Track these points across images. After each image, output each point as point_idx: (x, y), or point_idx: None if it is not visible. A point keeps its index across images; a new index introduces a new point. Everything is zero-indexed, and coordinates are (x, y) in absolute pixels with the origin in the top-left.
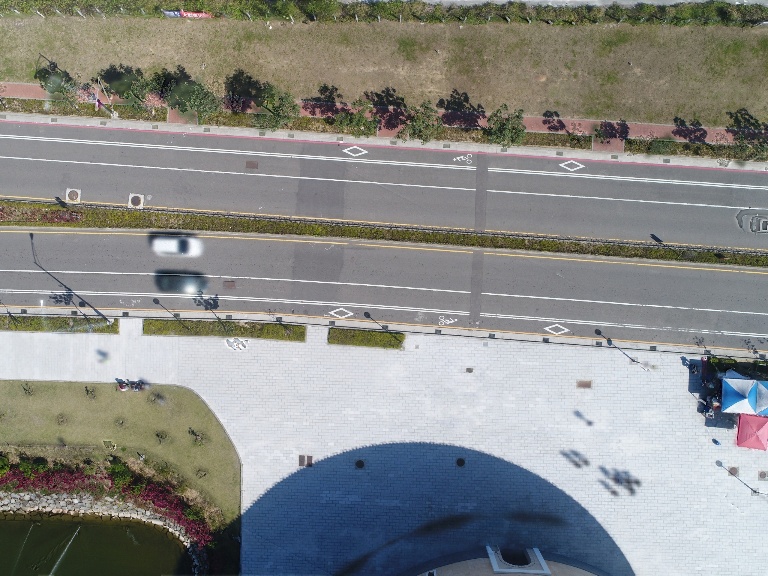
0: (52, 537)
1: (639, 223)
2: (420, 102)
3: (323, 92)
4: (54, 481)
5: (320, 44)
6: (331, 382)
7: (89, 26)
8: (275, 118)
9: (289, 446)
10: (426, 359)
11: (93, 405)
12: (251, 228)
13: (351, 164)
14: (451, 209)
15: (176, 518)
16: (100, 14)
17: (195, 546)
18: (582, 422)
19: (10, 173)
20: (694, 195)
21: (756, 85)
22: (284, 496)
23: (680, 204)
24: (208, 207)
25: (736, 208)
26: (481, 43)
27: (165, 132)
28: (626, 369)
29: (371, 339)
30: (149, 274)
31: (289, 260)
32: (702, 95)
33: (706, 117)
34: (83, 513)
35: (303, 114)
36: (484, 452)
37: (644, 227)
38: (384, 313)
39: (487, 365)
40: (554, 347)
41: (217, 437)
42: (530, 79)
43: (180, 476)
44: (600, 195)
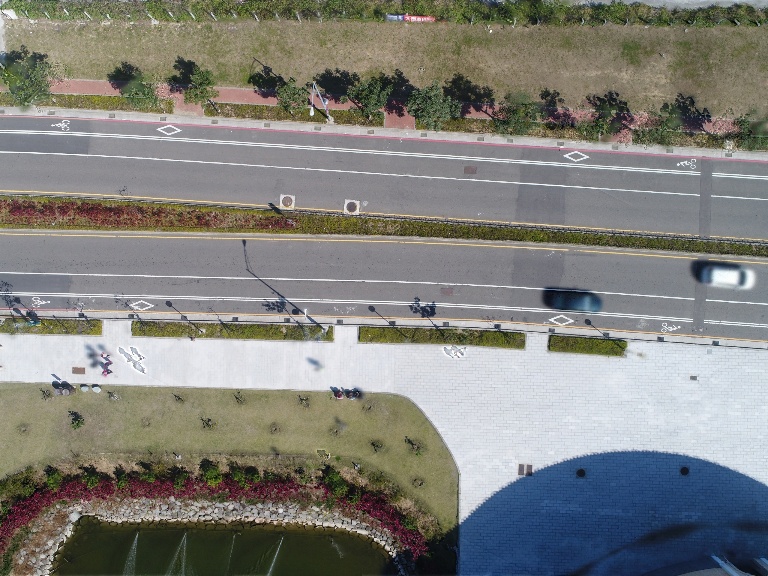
0: (253, 547)
1: None
2: (644, 106)
3: (544, 96)
4: (267, 491)
5: (542, 48)
6: (551, 390)
7: (304, 30)
8: (495, 123)
9: (508, 455)
10: (649, 367)
11: (307, 414)
12: (471, 234)
13: (572, 169)
14: (675, 215)
15: (391, 528)
16: (319, 18)
17: (402, 556)
18: None
19: (222, 179)
20: None
21: None
22: (503, 505)
23: None
24: (426, 213)
25: None
26: (707, 47)
27: (381, 137)
28: None
29: (593, 346)
30: (364, 281)
31: (508, 267)
32: None
33: None
34: (286, 523)
35: (523, 119)
36: (708, 461)
37: None
38: (605, 320)
39: (711, 373)
40: None
41: (434, 446)
42: (757, 83)
43: (395, 485)
44: None
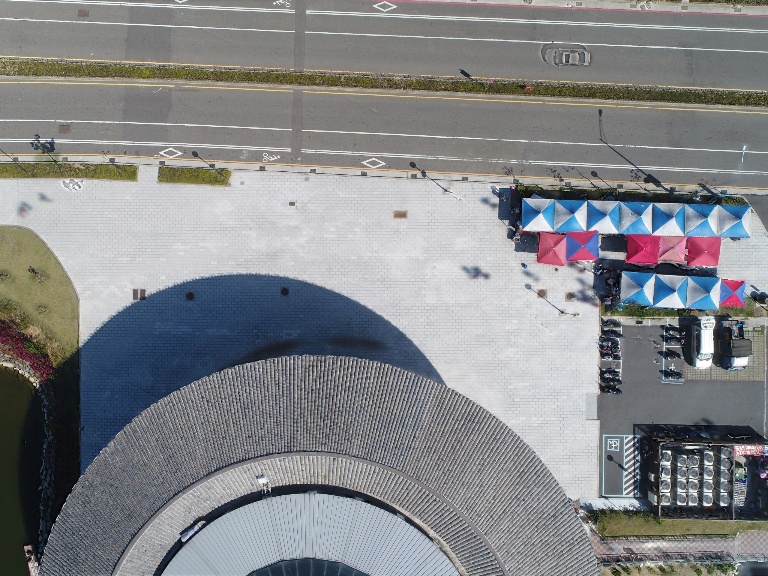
0: None
1: (449, 59)
2: None
3: None
4: None
5: None
6: (162, 219)
7: None
8: None
9: (123, 281)
10: (251, 194)
11: None
12: (82, 72)
13: (177, 10)
14: (272, 50)
15: (19, 353)
16: None
17: (43, 386)
18: (398, 250)
19: None
20: (500, 31)
21: None
22: (119, 328)
23: (487, 40)
24: (43, 54)
25: (540, 43)
26: None
27: None
28: (439, 199)
29: (198, 176)
30: None
31: (120, 103)
32: None
33: None
34: None
35: None
36: (307, 281)
37: (453, 63)
38: (211, 152)
39: (308, 198)
40: (371, 180)
41: (55, 274)
42: None
43: (22, 313)
44: (412, 34)
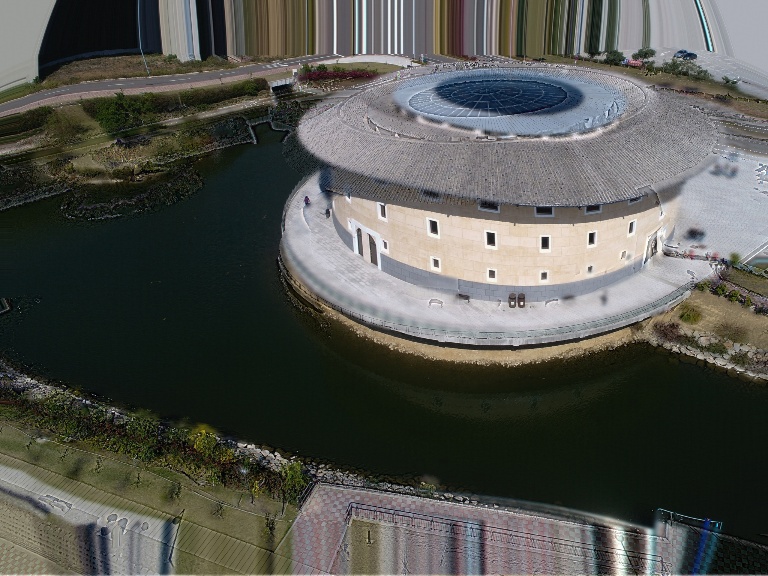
0: None
1: None
2: None
3: None
4: None
5: None
6: None
7: None
8: None
9: None
10: None
11: None
12: None
13: None
14: None
15: None
16: None
17: None
18: None
19: None
20: None
21: None
22: None
23: None
24: None
25: None
26: None
27: None
28: None
29: None
30: None
31: None
32: None
33: None
34: None
35: None
36: None
37: None
38: None
39: None
40: None
41: None
42: None
43: None
44: None
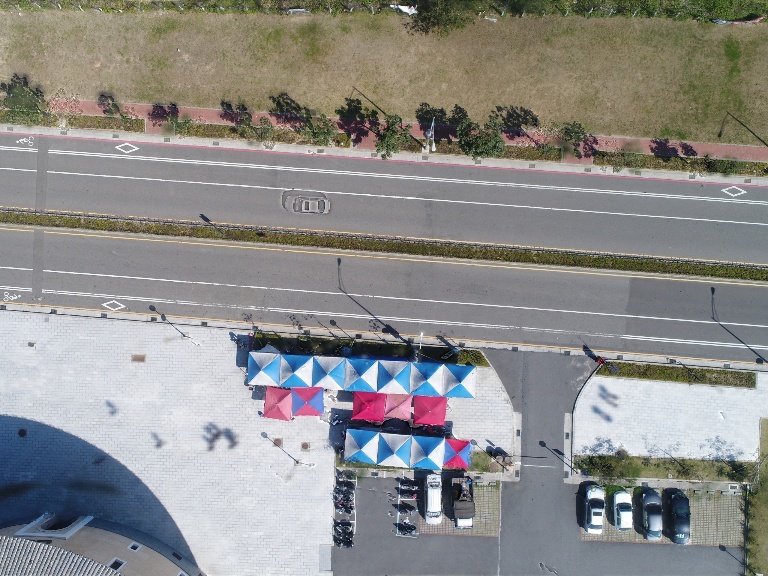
0: None
1: (189, 203)
2: None
3: None
4: None
5: None
6: None
7: None
8: None
9: None
10: None
11: None
12: None
13: None
14: (13, 189)
15: None
16: None
17: None
18: (136, 395)
19: None
20: (241, 177)
21: (296, 71)
22: None
23: (228, 185)
24: None
25: (280, 189)
26: (39, 30)
27: None
28: (178, 344)
29: None
30: None
31: None
32: (246, 80)
33: (250, 101)
34: None
35: None
36: (44, 423)
37: (194, 207)
38: None
39: (48, 339)
40: (111, 322)
41: None
42: (85, 64)
43: None
44: (153, 176)
